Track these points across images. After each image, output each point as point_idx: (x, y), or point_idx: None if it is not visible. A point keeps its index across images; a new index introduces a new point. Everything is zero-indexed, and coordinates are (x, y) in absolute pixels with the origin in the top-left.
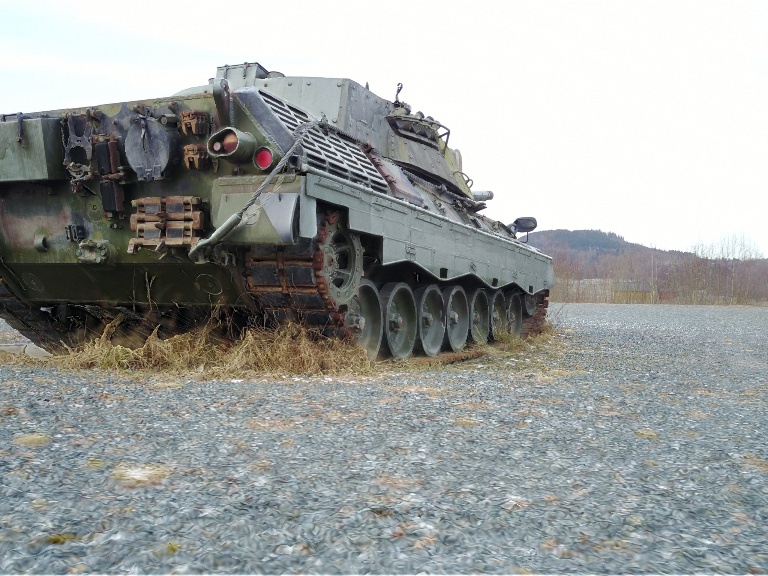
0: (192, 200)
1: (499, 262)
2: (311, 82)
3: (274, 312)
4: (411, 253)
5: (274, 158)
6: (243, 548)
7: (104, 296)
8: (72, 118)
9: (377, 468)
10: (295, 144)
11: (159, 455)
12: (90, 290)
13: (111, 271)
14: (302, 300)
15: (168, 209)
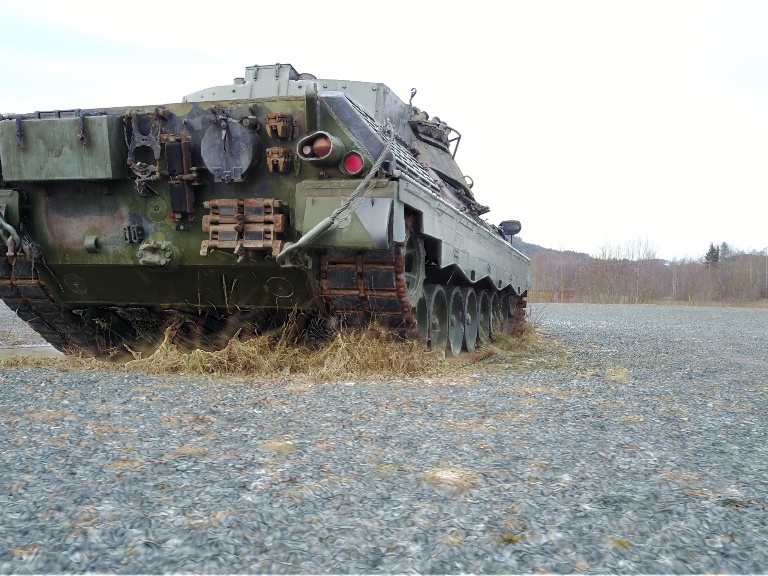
0: (273, 203)
1: (503, 264)
2: (347, 85)
3: (345, 315)
4: (456, 256)
5: (364, 163)
6: (674, 543)
7: (156, 298)
8: (136, 116)
9: (633, 466)
10: (386, 149)
11: (410, 459)
12: (141, 292)
13: (172, 273)
14: (380, 303)
15: (246, 211)
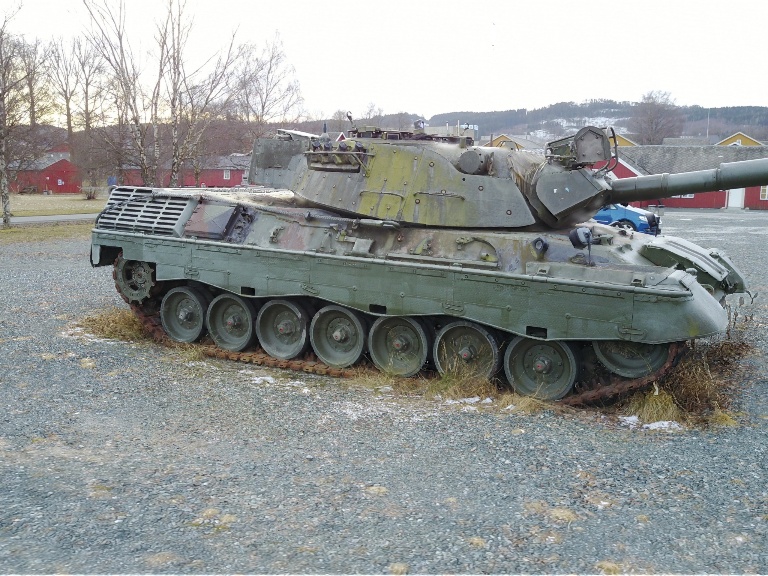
0: None
1: (390, 288)
2: None
3: None
4: None
5: None
6: None
7: None
8: None
9: None
10: None
11: None
12: None
13: None
14: None
15: None
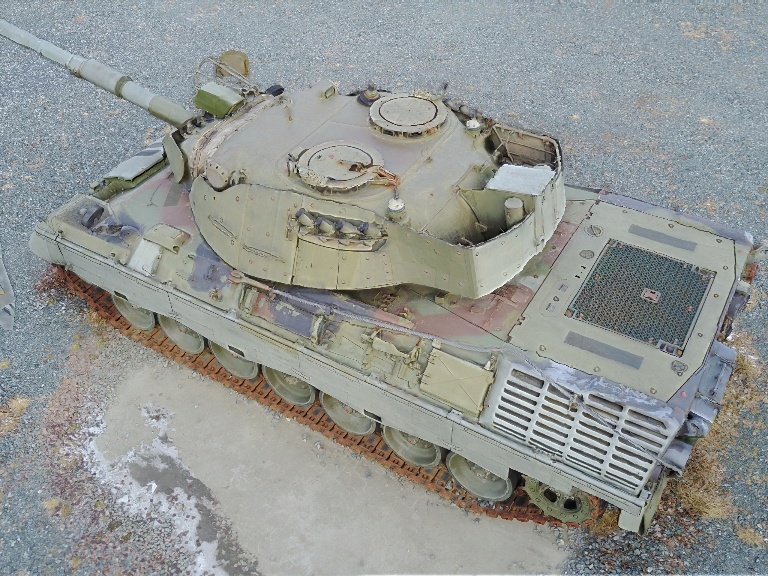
0: None
1: None
2: None
3: None
4: None
5: None
6: None
7: None
8: None
9: None
10: None
11: None
12: None
13: None
14: None
15: None
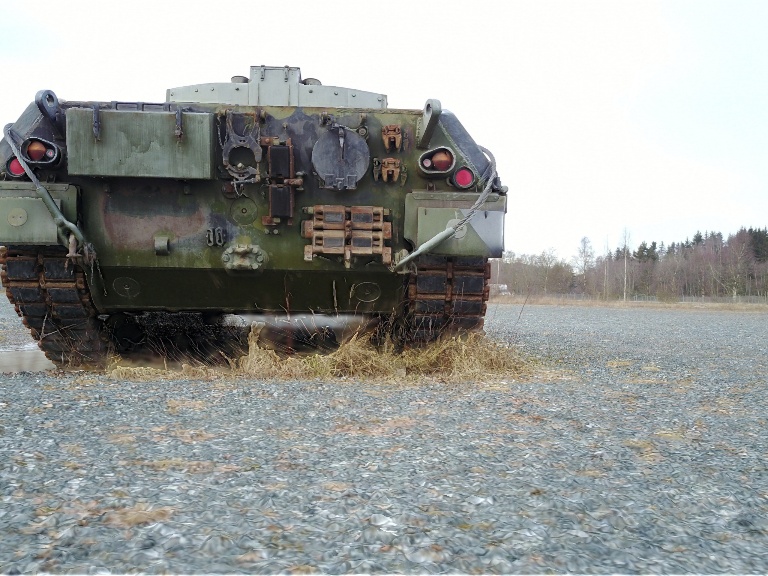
0: (384, 211)
1: None
2: (356, 94)
3: (424, 318)
4: None
5: (475, 178)
6: None
7: (220, 303)
8: (232, 116)
9: None
10: None
11: (762, 440)
12: (205, 296)
13: (254, 277)
14: (465, 307)
15: (354, 218)
